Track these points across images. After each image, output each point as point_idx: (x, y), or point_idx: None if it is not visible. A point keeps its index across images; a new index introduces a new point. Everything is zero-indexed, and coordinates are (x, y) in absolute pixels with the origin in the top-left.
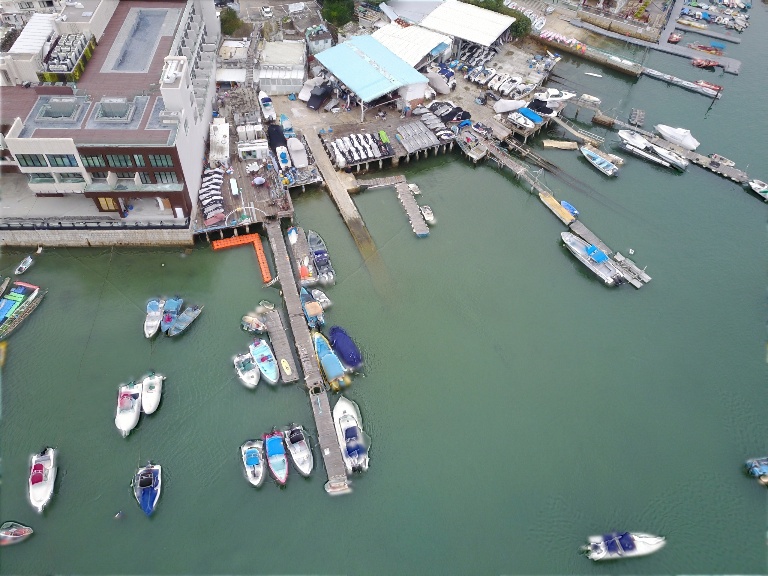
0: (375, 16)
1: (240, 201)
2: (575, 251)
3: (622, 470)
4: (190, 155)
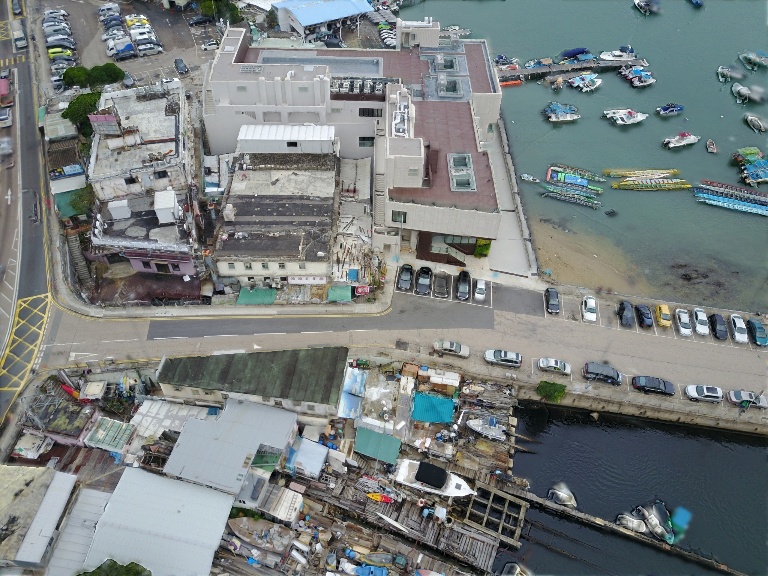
0: (236, 1)
1: None
2: None
3: (602, 8)
4: None
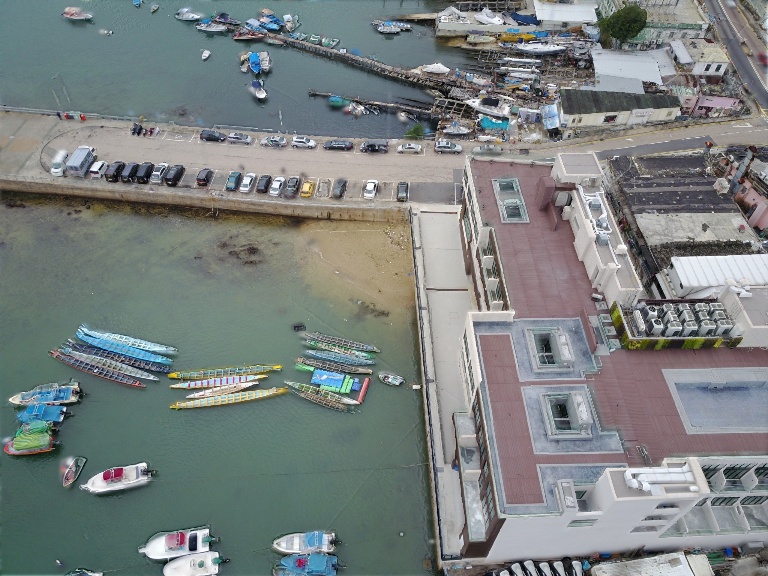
0: None
1: None
2: None
3: None
4: (555, 537)
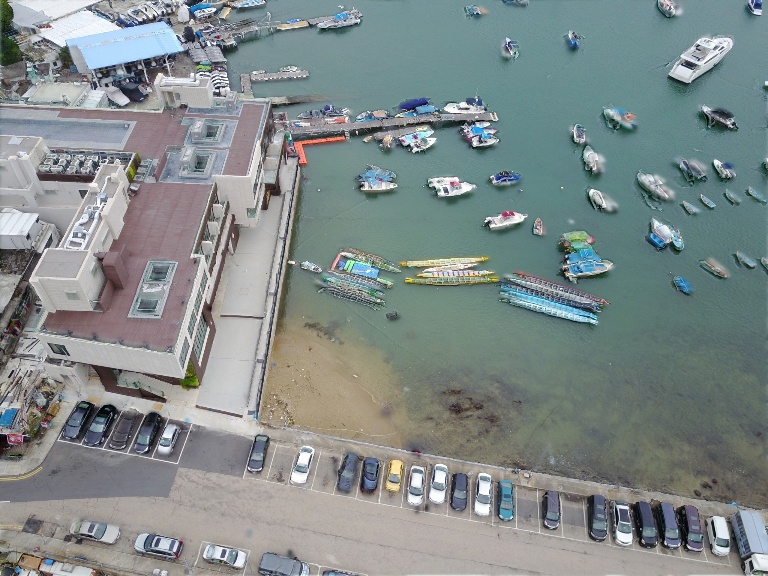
0: (26, 35)
1: None
2: (337, 24)
3: (472, 47)
4: None
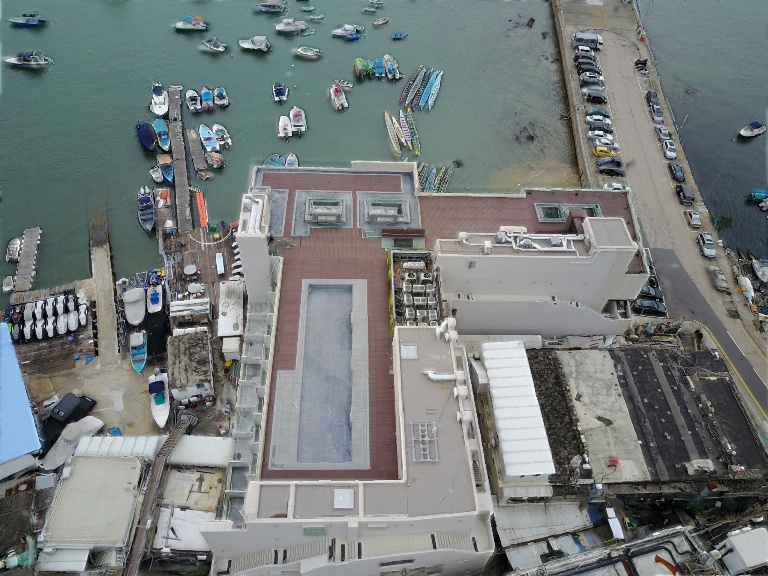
0: None
1: (216, 251)
2: None
3: None
4: None
